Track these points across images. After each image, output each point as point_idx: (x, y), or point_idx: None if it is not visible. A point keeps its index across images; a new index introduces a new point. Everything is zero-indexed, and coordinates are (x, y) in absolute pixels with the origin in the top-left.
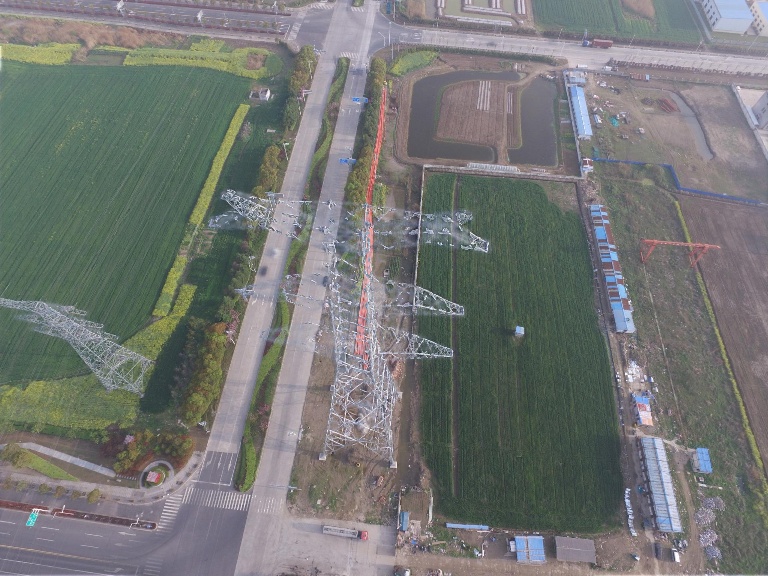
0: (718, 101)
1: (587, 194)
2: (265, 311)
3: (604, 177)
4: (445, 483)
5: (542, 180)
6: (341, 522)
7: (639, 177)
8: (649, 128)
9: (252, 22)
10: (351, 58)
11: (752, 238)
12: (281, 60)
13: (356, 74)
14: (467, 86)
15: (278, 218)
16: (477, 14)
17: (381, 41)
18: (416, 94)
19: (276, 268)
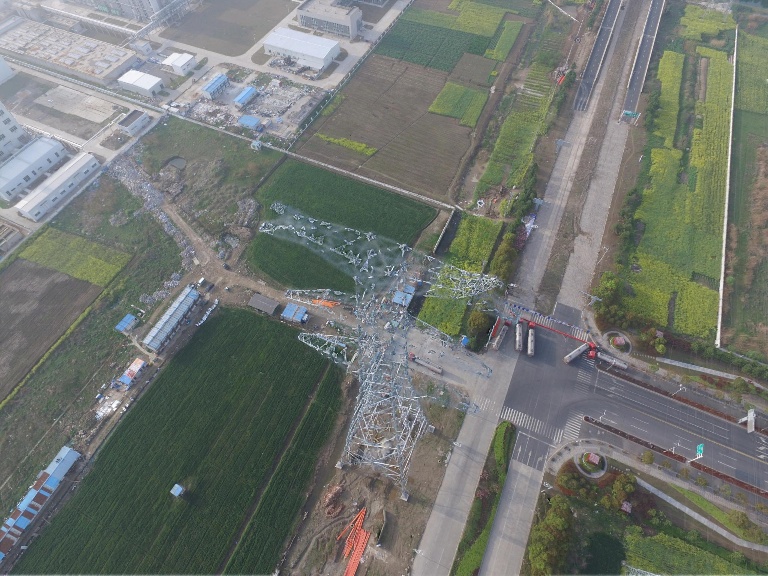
0: None
1: None
2: None
3: None
4: (333, 374)
5: None
6: None
7: None
8: None
9: None
10: None
11: None
12: None
13: None
14: None
15: None
16: None
17: None
18: None
19: None
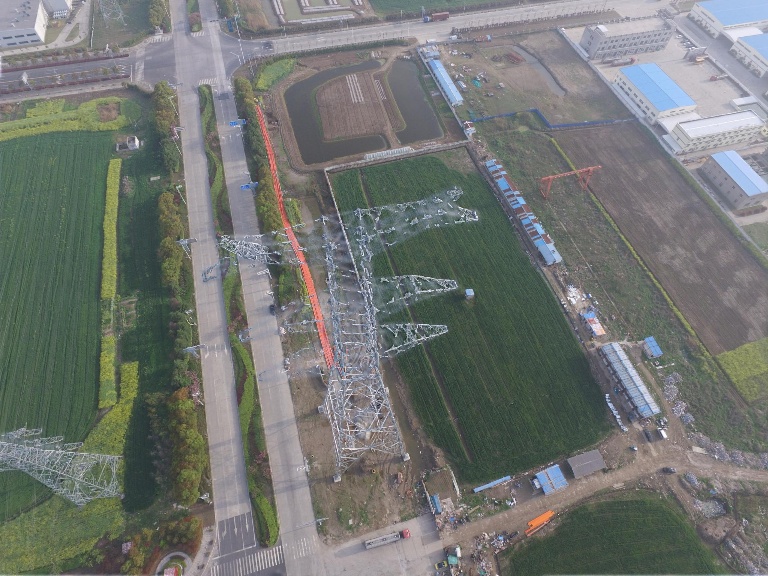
0: (552, 44)
1: (479, 153)
2: (222, 360)
3: (487, 134)
4: (458, 454)
5: (436, 152)
6: (379, 531)
7: (515, 126)
8: (507, 81)
9: (88, 72)
10: (211, 84)
11: (619, 152)
12: (137, 104)
13: (222, 99)
14: (335, 84)
15: (198, 264)
16: (318, 14)
17: (235, 60)
18: (290, 103)
19: (216, 314)
